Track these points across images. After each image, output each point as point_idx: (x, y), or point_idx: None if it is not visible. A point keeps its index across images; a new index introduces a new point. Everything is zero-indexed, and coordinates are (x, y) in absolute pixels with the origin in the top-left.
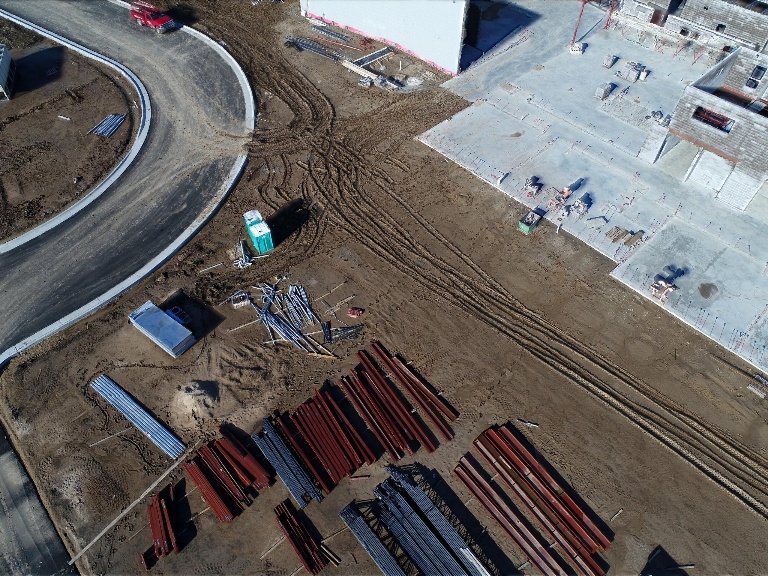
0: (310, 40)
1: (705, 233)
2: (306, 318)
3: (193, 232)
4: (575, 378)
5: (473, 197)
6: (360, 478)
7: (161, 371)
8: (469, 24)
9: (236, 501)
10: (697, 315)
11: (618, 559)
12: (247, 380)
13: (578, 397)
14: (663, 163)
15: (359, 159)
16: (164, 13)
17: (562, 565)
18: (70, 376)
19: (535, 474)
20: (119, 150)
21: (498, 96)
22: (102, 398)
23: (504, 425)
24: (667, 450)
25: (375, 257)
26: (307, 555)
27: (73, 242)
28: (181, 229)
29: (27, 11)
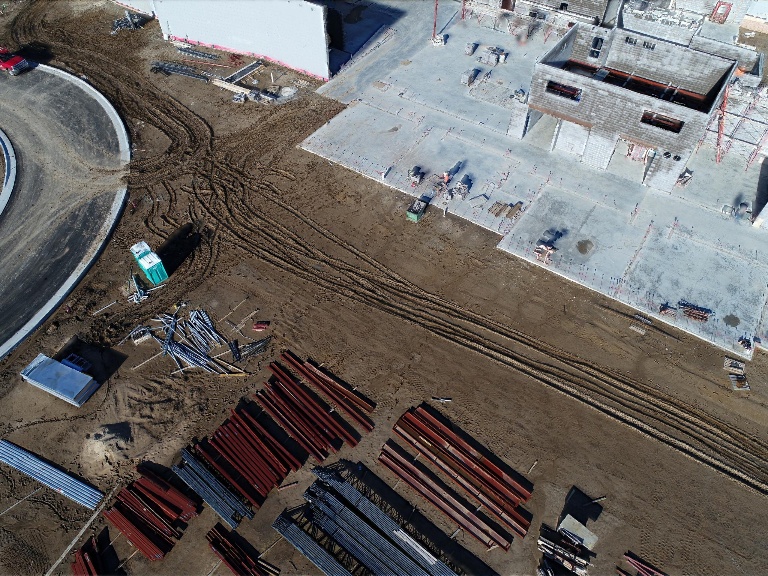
0: (177, 63)
1: (575, 195)
2: (212, 341)
3: (80, 275)
4: (479, 349)
5: (361, 195)
6: (288, 486)
7: (65, 423)
8: (333, 29)
9: (165, 537)
10: (578, 271)
11: (539, 507)
12: (159, 414)
13: (484, 366)
14: (531, 137)
15: (244, 175)
16: (14, 54)
17: (490, 524)
18: None
19: (454, 446)
20: None
21: (371, 95)
22: (4, 464)
23: (420, 406)
24: (569, 398)
25: (273, 269)
26: (245, 573)
27: None
28: (66, 274)
29: None
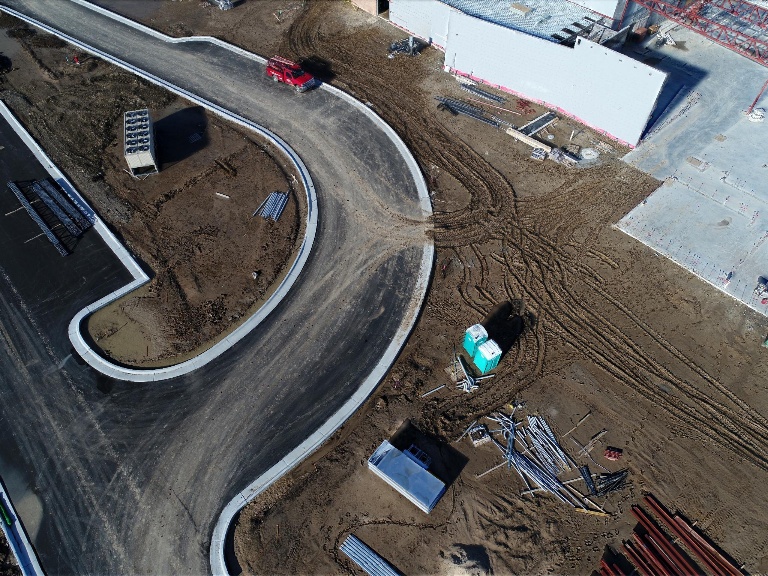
0: (463, 102)
1: None
2: (559, 460)
3: (402, 344)
4: None
5: (700, 302)
6: None
7: (415, 530)
8: None
9: None
10: None
11: None
12: (516, 544)
13: None
14: None
15: (558, 251)
16: (303, 70)
17: None
18: (313, 535)
19: None
20: (292, 237)
21: (688, 174)
22: (357, 566)
23: None
24: None
25: (613, 379)
26: None
27: (272, 355)
28: (387, 340)
29: (151, 63)
